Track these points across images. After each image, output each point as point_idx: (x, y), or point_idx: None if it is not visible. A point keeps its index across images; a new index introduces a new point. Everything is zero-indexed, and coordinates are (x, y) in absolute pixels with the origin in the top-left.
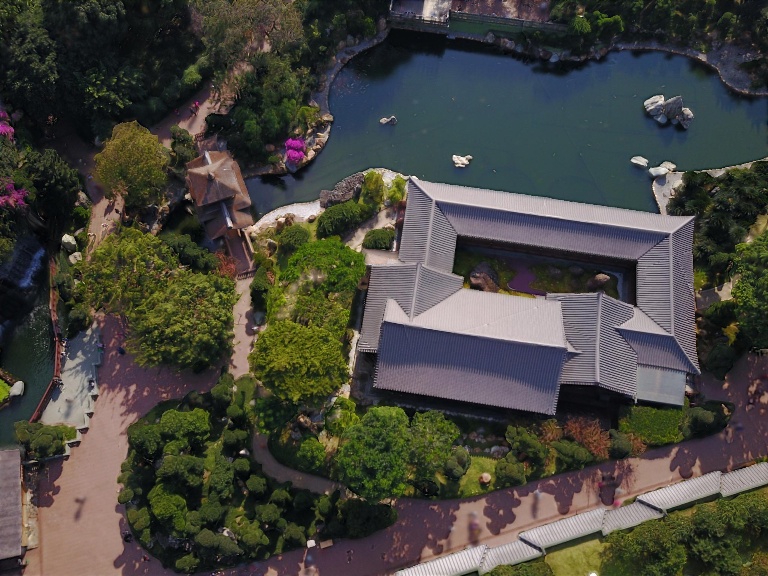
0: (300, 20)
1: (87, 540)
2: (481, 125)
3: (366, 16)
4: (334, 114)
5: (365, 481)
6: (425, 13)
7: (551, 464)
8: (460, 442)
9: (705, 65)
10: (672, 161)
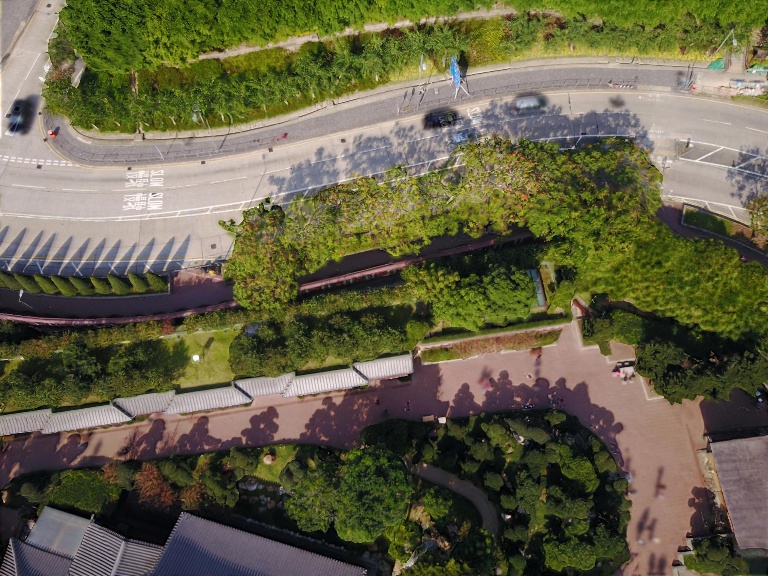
0: None
1: (652, 451)
2: None
3: None
4: None
5: (387, 465)
6: None
7: (201, 465)
8: (286, 499)
9: None
10: None
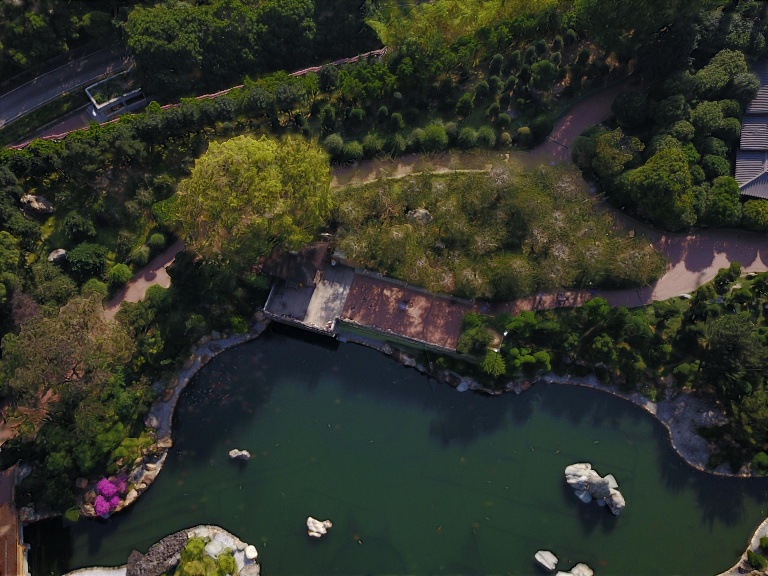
0: (131, 339)
1: None
2: (356, 470)
3: (236, 311)
4: (176, 435)
5: None
6: (309, 313)
7: None
8: None
9: (654, 419)
10: (590, 560)
